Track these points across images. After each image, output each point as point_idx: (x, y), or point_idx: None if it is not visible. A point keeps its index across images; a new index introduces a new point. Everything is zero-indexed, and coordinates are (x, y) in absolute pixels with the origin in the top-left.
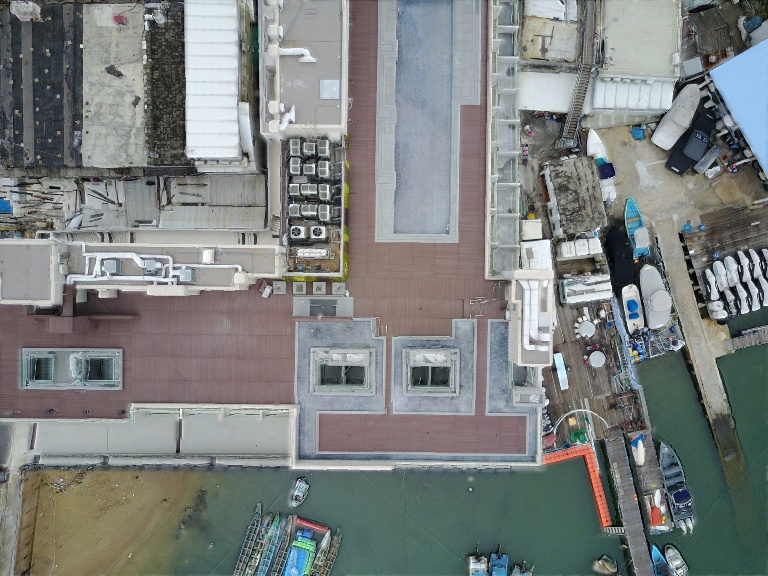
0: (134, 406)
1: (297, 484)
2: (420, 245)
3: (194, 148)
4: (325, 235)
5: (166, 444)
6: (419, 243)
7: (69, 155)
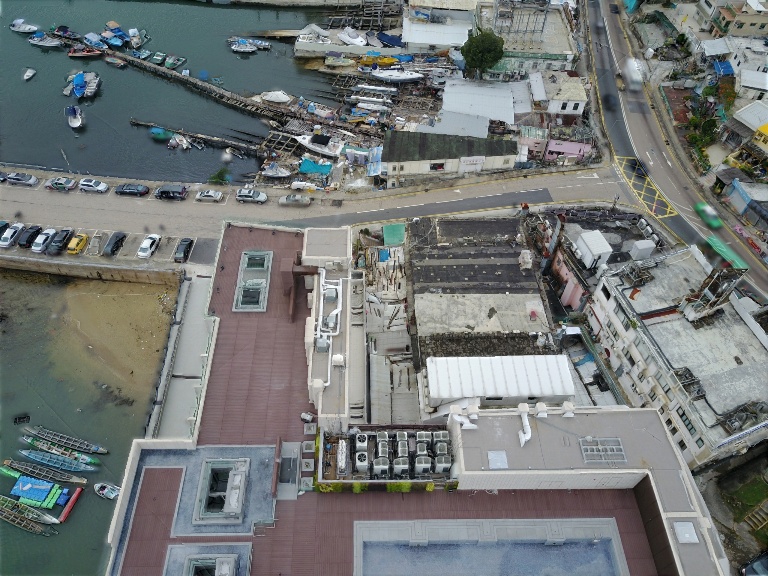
0: (217, 319)
1: (117, 487)
2: (351, 572)
3: (435, 363)
4: (360, 467)
5: (182, 367)
6: (353, 570)
7: (422, 286)
